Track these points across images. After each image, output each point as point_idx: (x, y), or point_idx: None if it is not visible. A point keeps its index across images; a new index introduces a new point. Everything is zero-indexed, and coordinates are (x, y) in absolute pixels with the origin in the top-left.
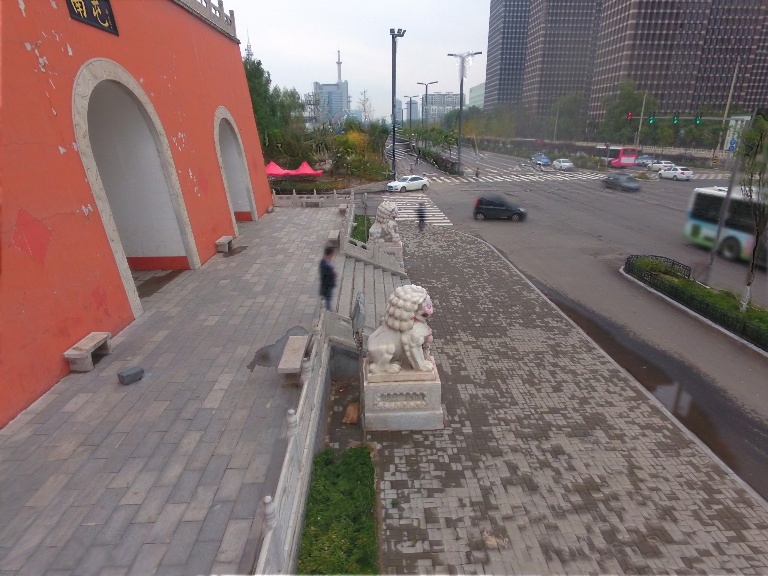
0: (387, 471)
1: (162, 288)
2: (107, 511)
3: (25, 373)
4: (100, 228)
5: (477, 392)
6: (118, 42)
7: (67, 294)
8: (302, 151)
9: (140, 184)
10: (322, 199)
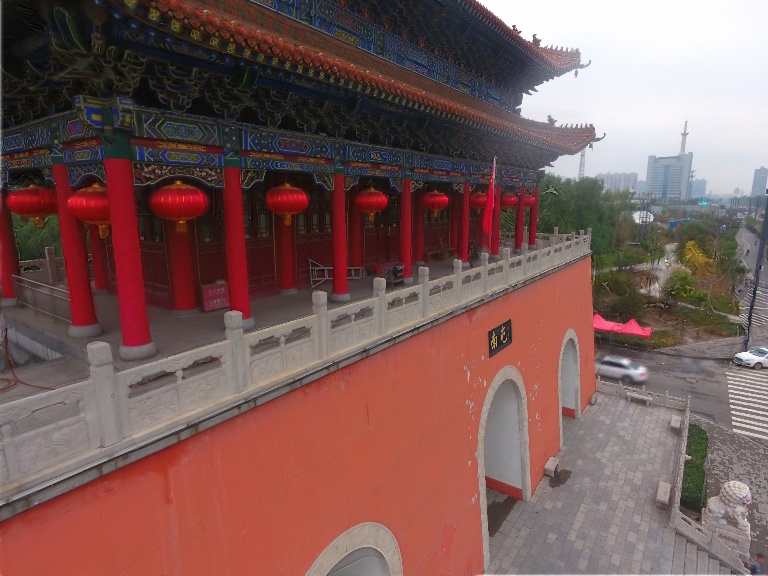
0: None
1: (502, 526)
2: None
3: None
4: (478, 508)
5: None
6: (511, 348)
7: (455, 572)
8: (630, 292)
9: (499, 428)
10: (651, 398)
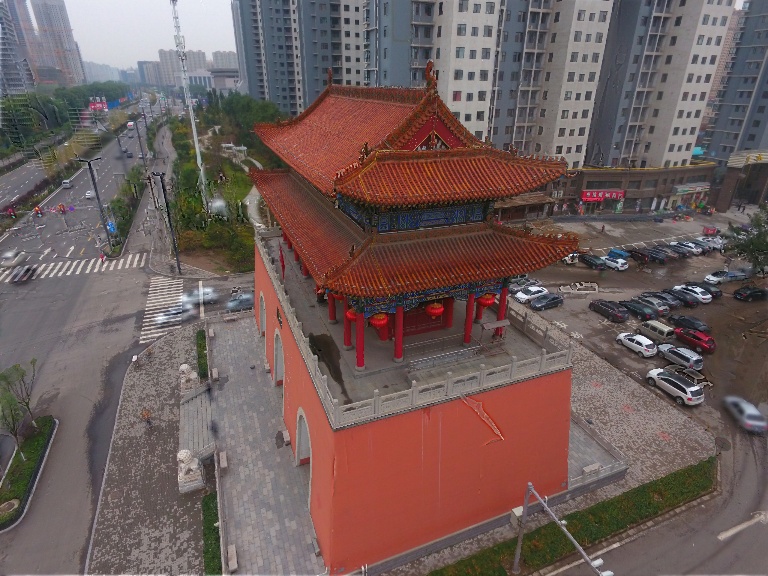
0: None
1: None
2: None
3: None
4: None
5: (169, 401)
6: None
7: None
8: None
9: None
10: None
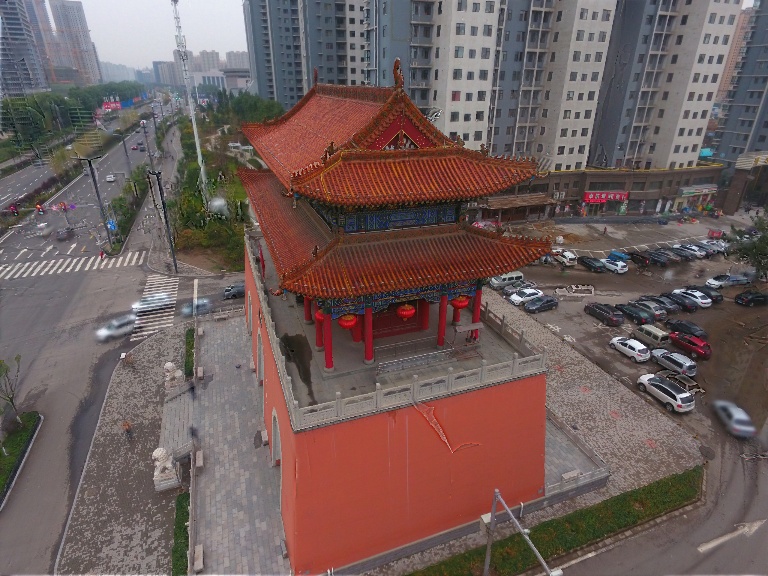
0: None
1: None
2: None
3: None
4: None
5: None
6: None
7: None
8: None
9: None
10: None
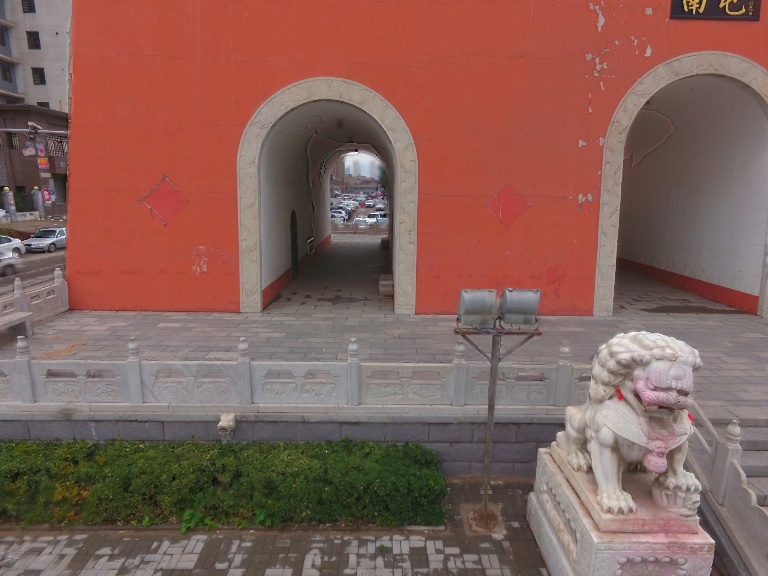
0: (444, 544)
1: (680, 313)
2: (333, 351)
3: (451, 293)
4: (593, 218)
5: None
6: (752, 28)
7: (519, 259)
8: None
9: (743, 199)
10: None
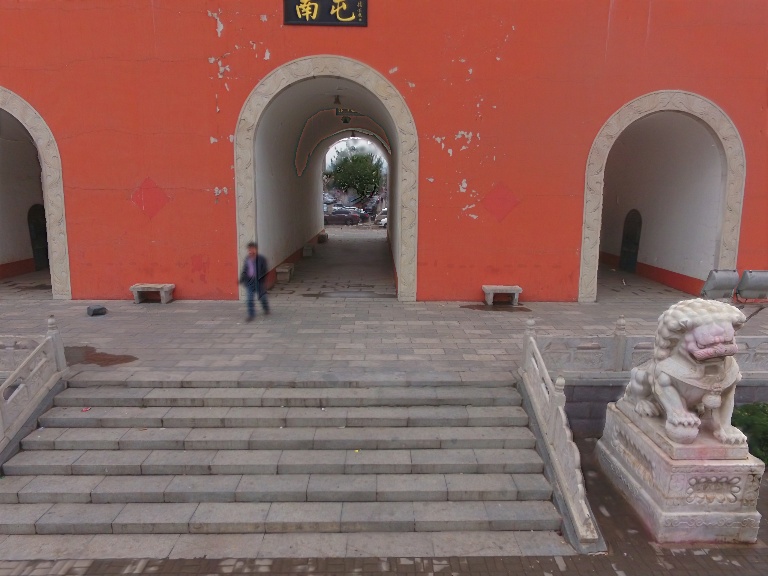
0: None
1: (330, 297)
2: None
3: (104, 280)
4: (230, 210)
5: None
6: (361, 33)
7: (166, 247)
8: None
9: None
10: None
